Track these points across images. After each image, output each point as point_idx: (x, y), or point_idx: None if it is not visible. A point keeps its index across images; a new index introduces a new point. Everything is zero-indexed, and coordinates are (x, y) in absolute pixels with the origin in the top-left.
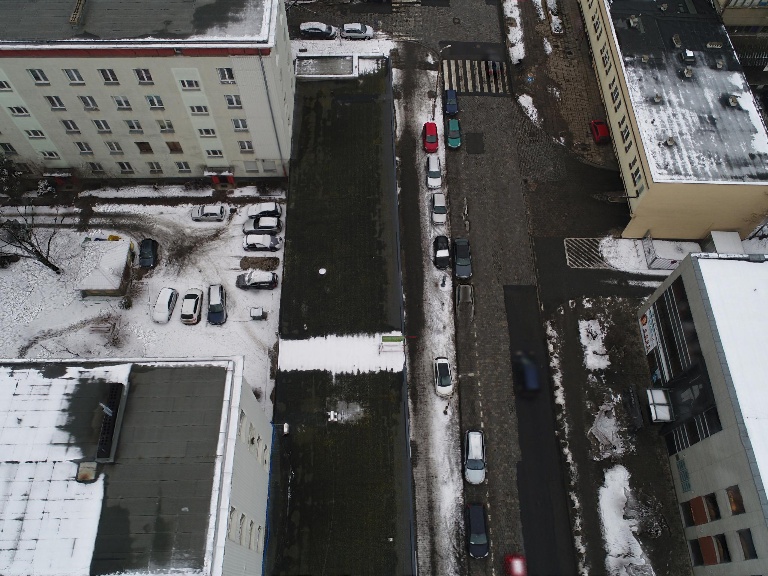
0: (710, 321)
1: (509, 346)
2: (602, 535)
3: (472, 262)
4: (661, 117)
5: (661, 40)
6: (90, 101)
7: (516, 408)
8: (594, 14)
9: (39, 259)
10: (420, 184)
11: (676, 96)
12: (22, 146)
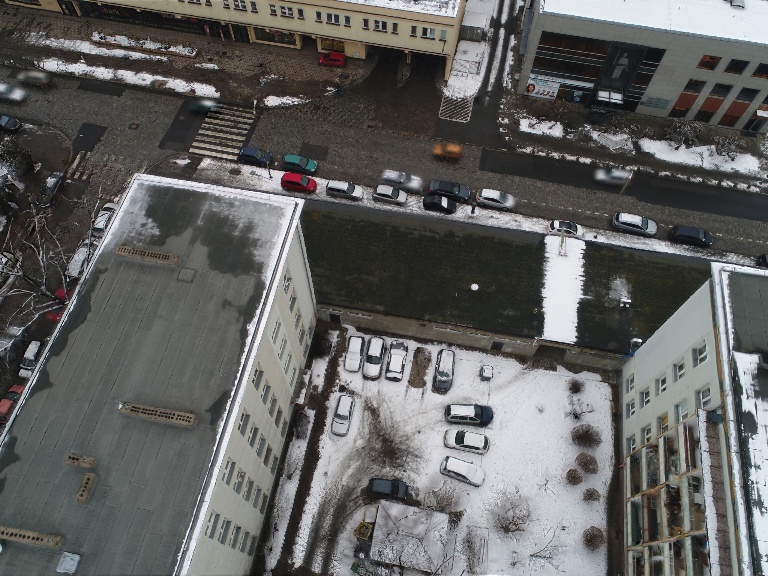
0: (598, 21)
1: (538, 180)
2: (689, 165)
3: None
4: None
5: None
6: None
7: (593, 189)
8: (223, 4)
9: None
10: None
11: None
12: None
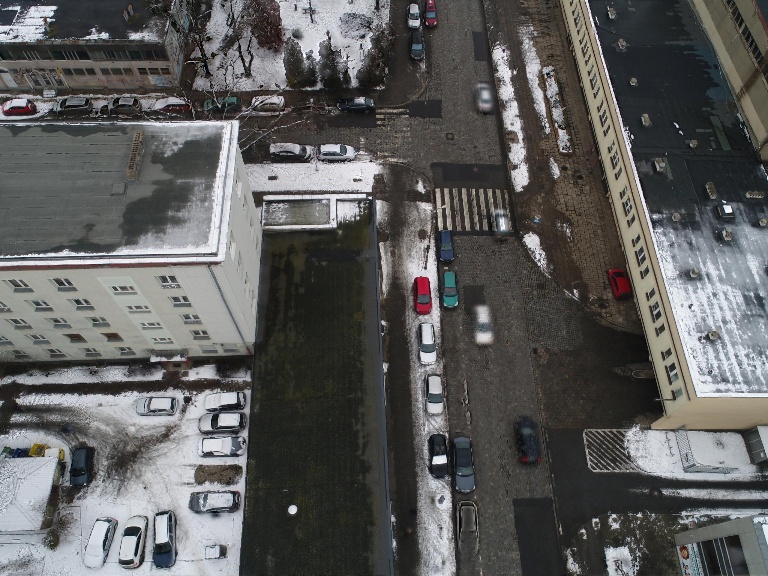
0: None
1: None
2: None
3: (475, 466)
4: (699, 298)
5: (692, 188)
6: None
7: None
8: (611, 145)
9: None
10: (411, 358)
11: (715, 267)
12: None
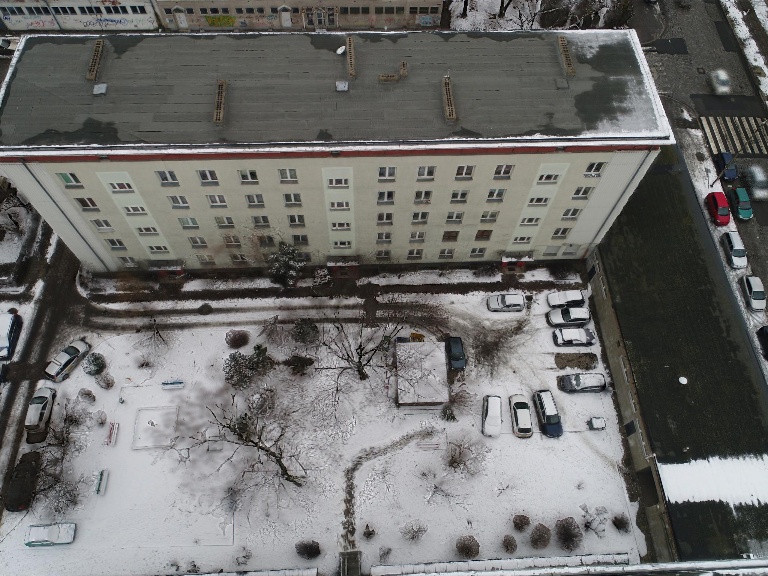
0: None
1: None
2: None
3: None
4: None
5: None
6: (424, 194)
7: None
8: None
9: (358, 369)
10: None
11: None
12: (318, 237)
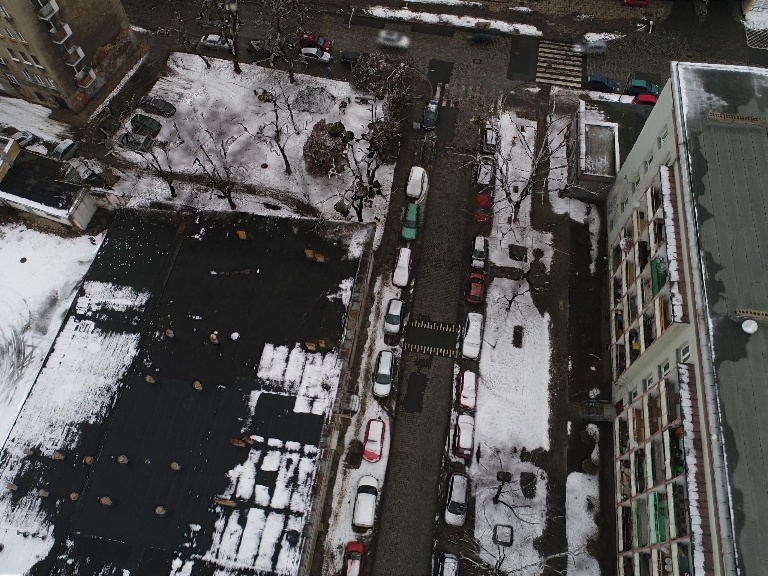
0: None
1: None
2: None
3: None
4: None
5: None
6: None
7: None
8: None
9: None
10: None
11: None
12: None
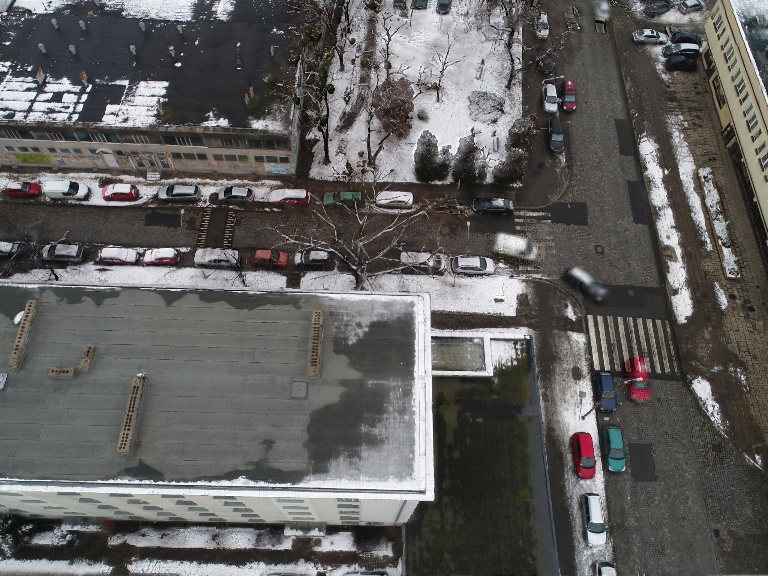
0: None
1: None
2: None
3: None
4: None
5: None
6: None
7: None
8: None
9: None
10: (575, 535)
11: None
12: None
